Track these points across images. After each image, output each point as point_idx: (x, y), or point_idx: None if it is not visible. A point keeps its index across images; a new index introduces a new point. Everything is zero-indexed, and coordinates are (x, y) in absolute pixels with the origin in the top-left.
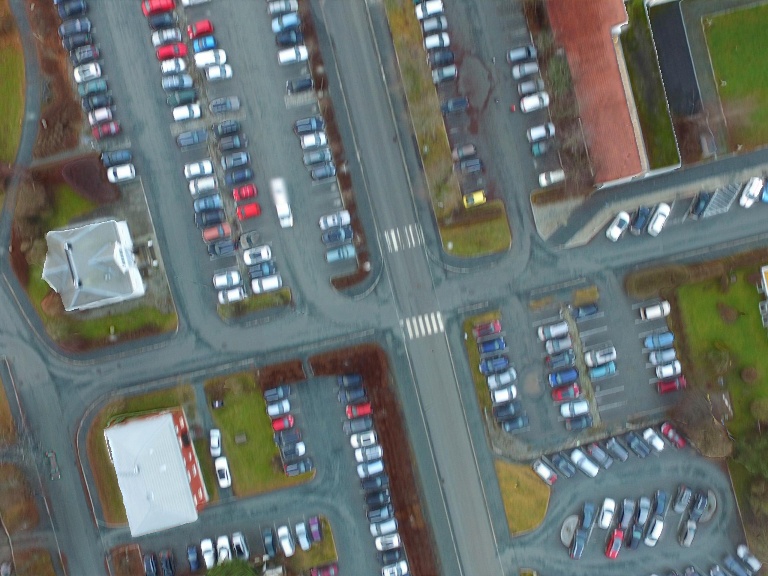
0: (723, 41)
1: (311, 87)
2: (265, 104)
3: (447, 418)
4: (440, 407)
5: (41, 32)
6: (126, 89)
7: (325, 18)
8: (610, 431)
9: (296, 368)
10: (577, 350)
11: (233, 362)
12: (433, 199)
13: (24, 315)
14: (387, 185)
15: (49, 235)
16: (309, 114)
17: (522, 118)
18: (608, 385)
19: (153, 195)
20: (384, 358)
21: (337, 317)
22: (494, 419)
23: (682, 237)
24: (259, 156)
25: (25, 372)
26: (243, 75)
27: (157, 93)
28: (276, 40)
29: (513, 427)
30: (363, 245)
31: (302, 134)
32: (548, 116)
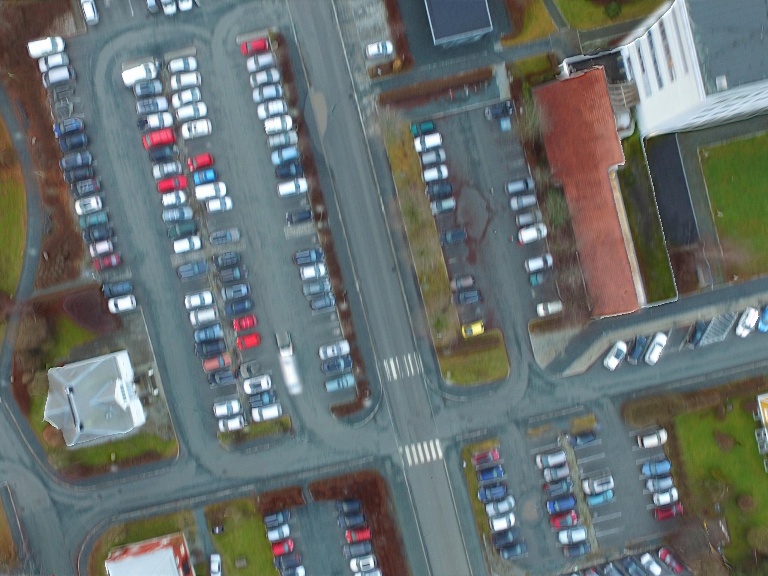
0: (719, 172)
1: (311, 218)
2: (265, 235)
3: (446, 544)
4: (439, 533)
5: (42, 165)
6: (127, 221)
7: (324, 150)
8: (608, 557)
9: (296, 495)
10: (575, 477)
11: (233, 488)
12: (432, 329)
13: (25, 442)
14: (386, 314)
15: (50, 373)
16: (309, 245)
17: (520, 249)
18: (606, 511)
19: (154, 324)
20: (383, 486)
21: (336, 444)
22: (492, 546)
23: (679, 365)
24: (259, 286)
25: (26, 498)
26: (243, 206)
27: (158, 224)
28: (276, 173)
29: (511, 555)
30: (362, 374)
31: (302, 266)
32: (546, 246)
